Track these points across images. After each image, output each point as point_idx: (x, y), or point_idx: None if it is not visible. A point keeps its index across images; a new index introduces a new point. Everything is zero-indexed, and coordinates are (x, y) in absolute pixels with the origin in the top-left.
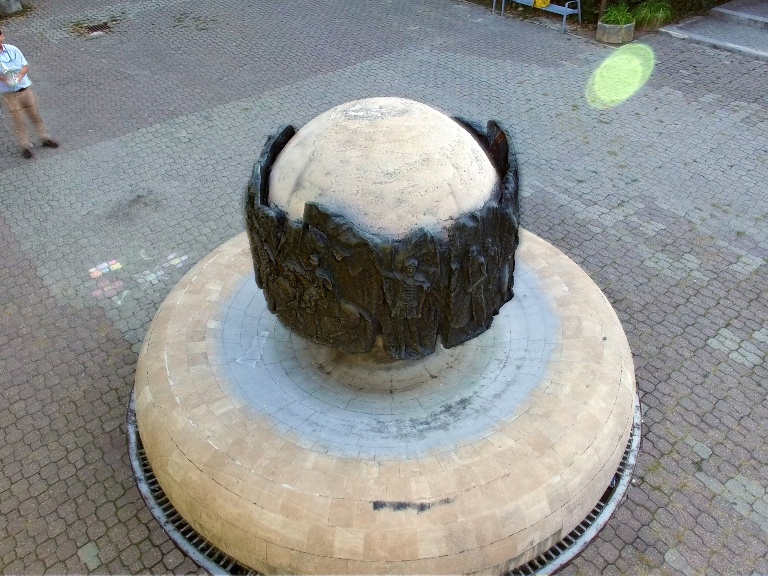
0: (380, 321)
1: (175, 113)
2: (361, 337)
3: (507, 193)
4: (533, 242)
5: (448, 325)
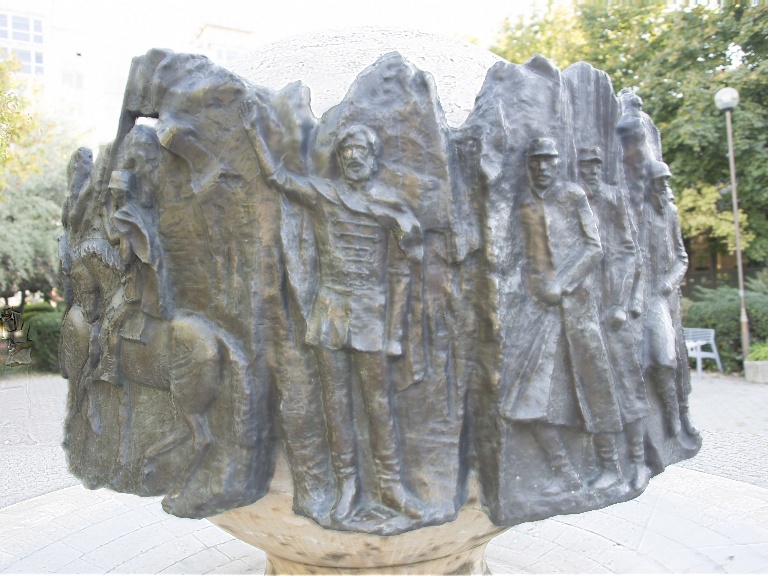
0: (274, 368)
1: None
2: (221, 440)
3: (630, 95)
4: (723, 479)
5: (494, 411)
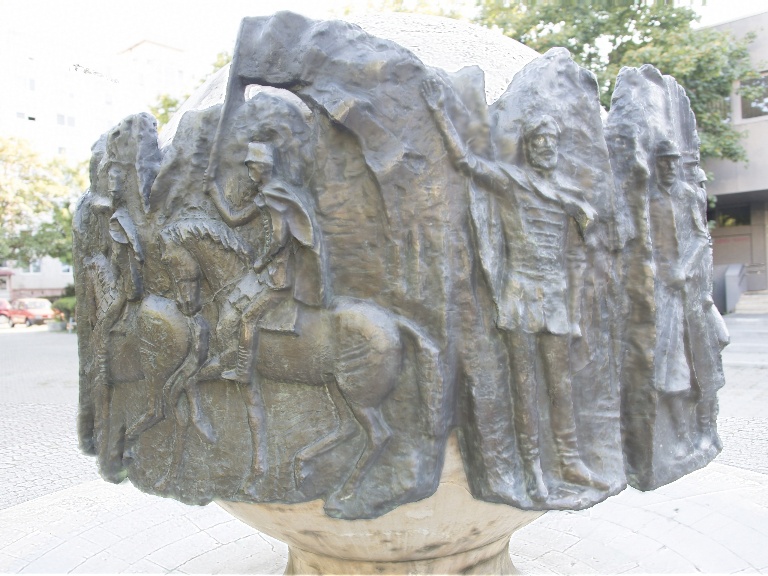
0: (463, 354)
1: (2, 445)
2: (403, 433)
3: None
4: None
5: (648, 386)
